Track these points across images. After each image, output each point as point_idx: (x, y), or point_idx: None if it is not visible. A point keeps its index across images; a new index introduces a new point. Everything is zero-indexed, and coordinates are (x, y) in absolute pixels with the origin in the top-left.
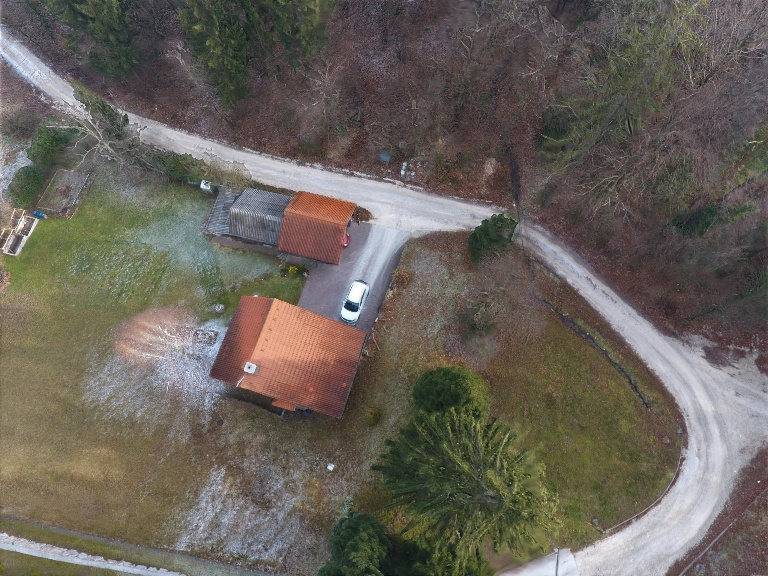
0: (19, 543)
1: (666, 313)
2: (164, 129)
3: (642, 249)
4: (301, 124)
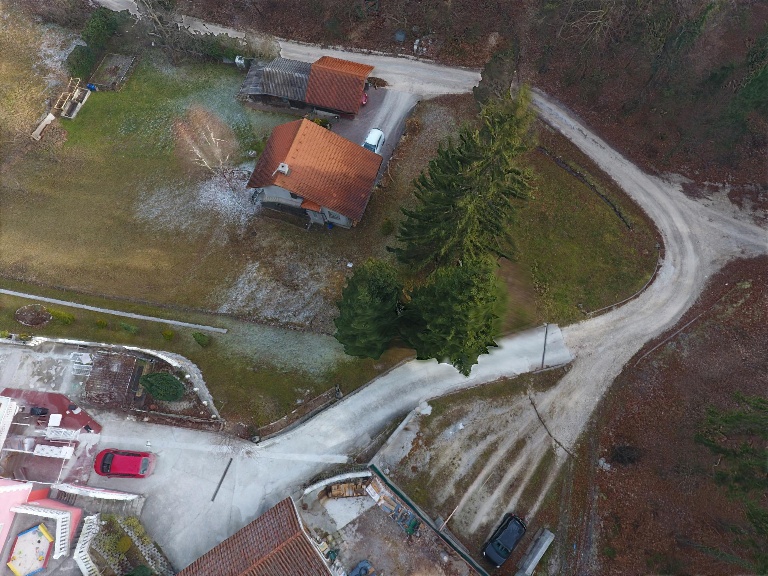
0: None
1: (649, 156)
2: (201, 24)
3: (628, 104)
4: (325, 13)
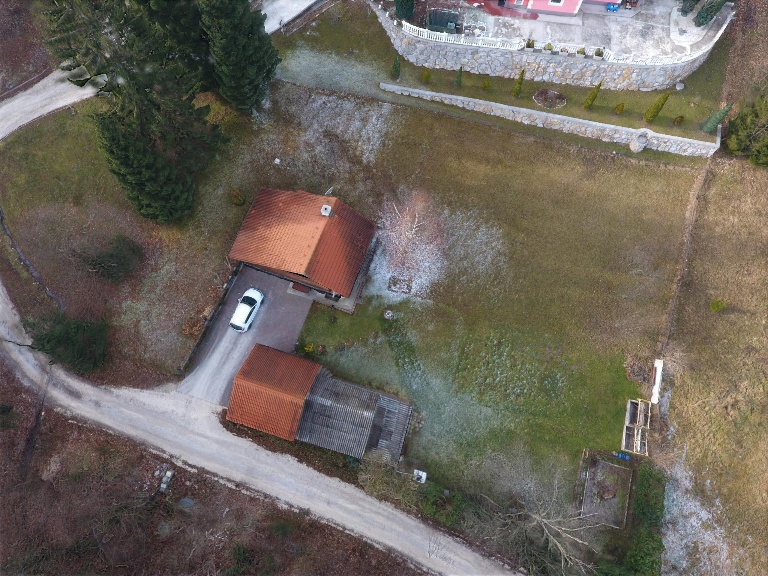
0: (510, 113)
1: None
2: None
3: None
4: None
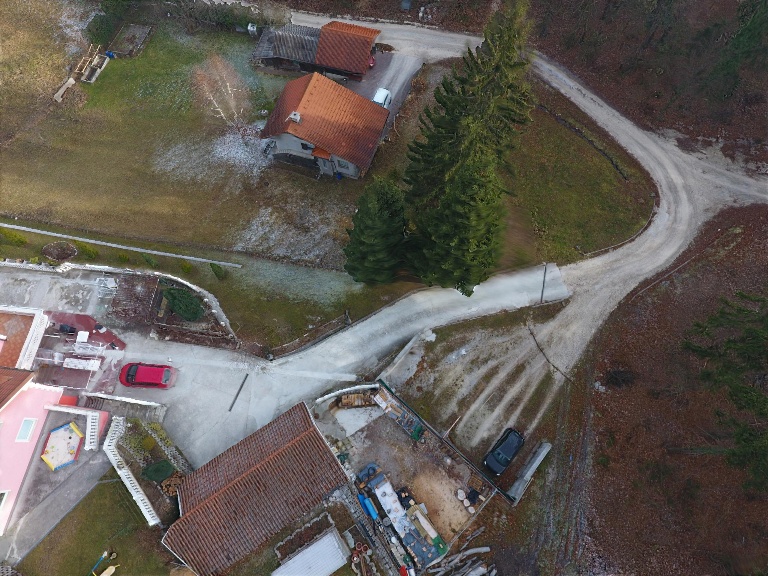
0: None
1: (645, 113)
2: None
3: (625, 65)
4: None
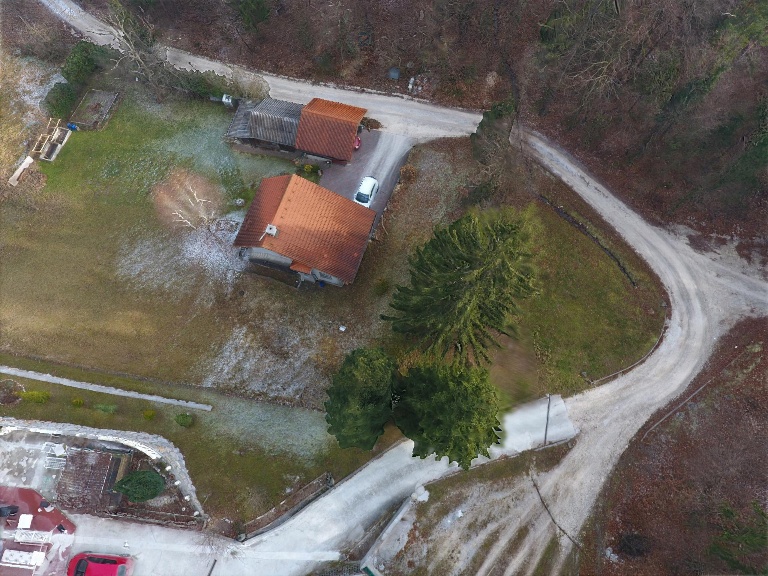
0: (62, 379)
1: (653, 206)
2: (187, 56)
3: (632, 150)
4: (316, 47)
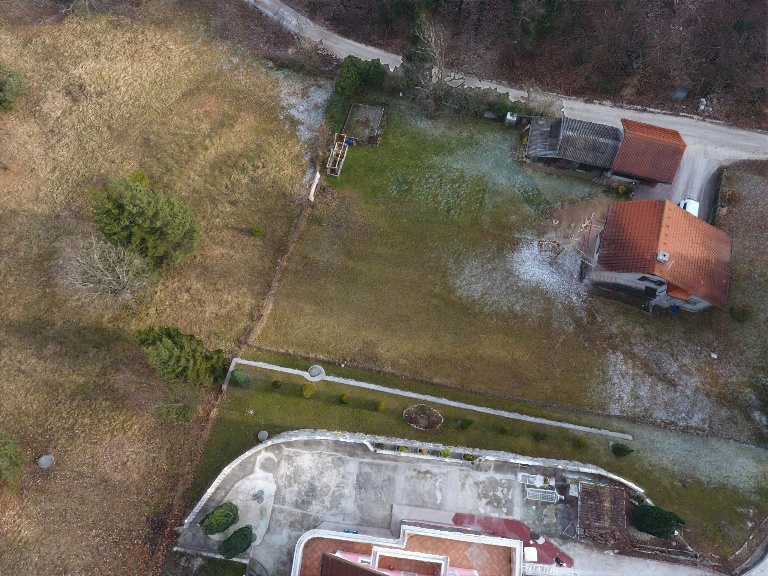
0: None
1: None
2: None
3: None
4: (587, 65)
